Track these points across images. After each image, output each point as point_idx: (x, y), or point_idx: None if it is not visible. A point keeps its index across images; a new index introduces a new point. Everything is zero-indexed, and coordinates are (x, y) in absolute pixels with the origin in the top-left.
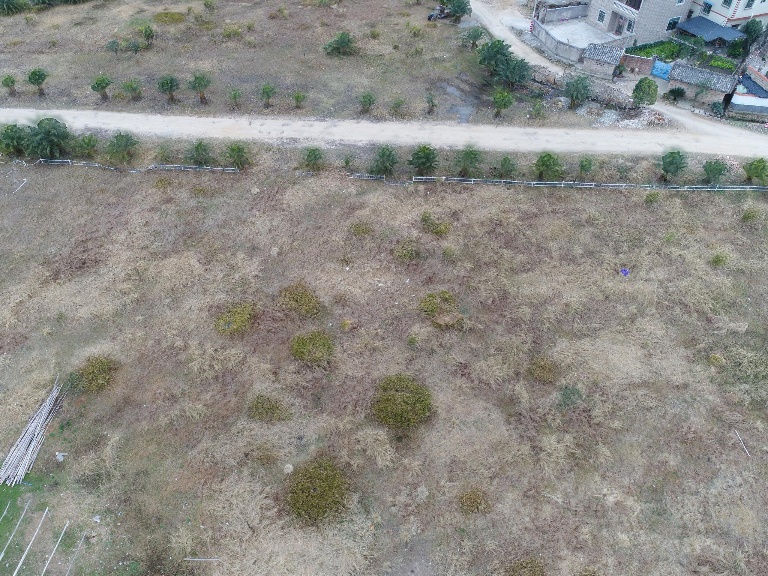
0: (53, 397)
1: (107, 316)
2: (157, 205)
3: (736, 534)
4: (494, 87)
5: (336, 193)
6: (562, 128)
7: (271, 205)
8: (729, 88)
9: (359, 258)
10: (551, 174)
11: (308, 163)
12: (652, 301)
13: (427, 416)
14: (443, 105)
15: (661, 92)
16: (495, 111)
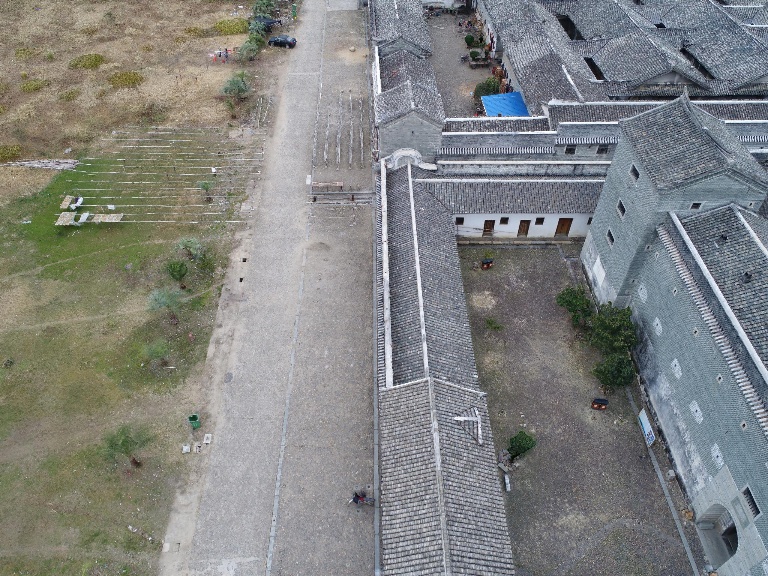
0: None
1: None
2: None
3: (180, 8)
4: None
5: None
6: None
7: None
8: None
9: None
10: None
11: None
12: (63, 5)
13: None
14: None
15: None
16: None
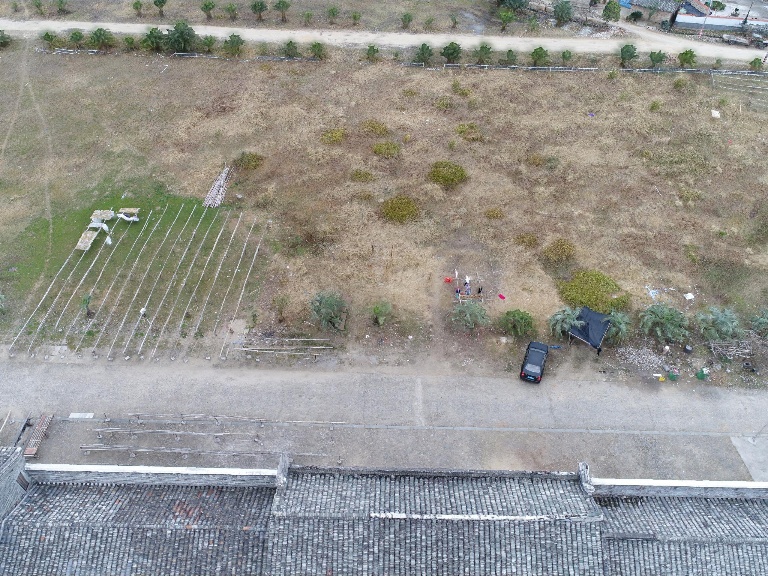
0: (226, 171)
1: (249, 134)
2: (265, 80)
3: (649, 227)
4: (500, 13)
5: (390, 74)
6: (551, 38)
7: (346, 80)
8: (673, 9)
9: (411, 108)
10: (542, 62)
11: (368, 56)
12: (608, 128)
13: (464, 179)
14: (462, 24)
15: (625, 16)
16: (501, 27)
